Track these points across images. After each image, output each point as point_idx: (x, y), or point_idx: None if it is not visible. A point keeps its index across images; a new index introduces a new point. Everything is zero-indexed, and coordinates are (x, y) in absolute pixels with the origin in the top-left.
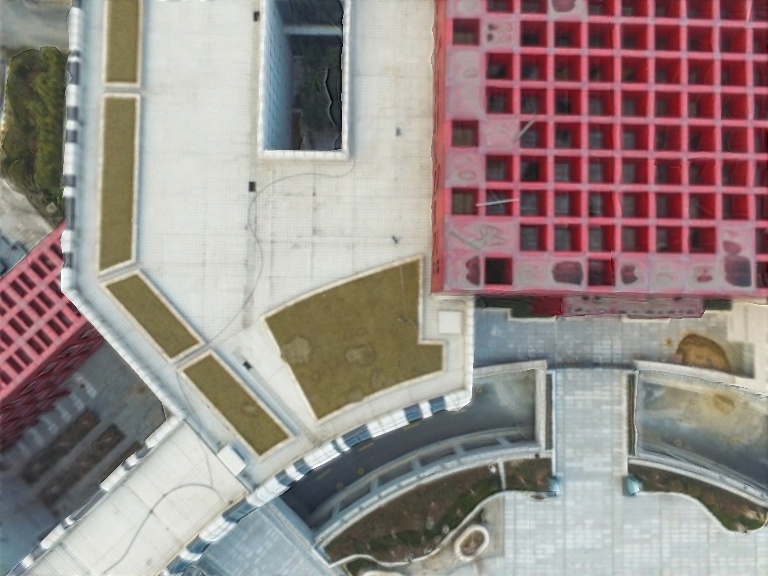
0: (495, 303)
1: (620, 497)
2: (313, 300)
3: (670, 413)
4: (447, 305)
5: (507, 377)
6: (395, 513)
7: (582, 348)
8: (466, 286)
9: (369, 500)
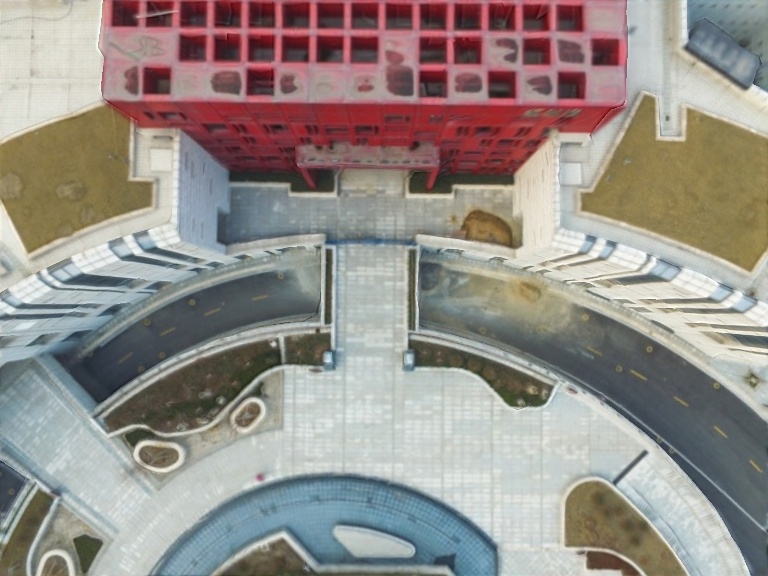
0: (271, 176)
1: (401, 373)
2: (26, 138)
3: (475, 301)
4: (158, 143)
5: (309, 263)
6: (174, 385)
7: (365, 224)
8: (125, 96)
9: (149, 372)
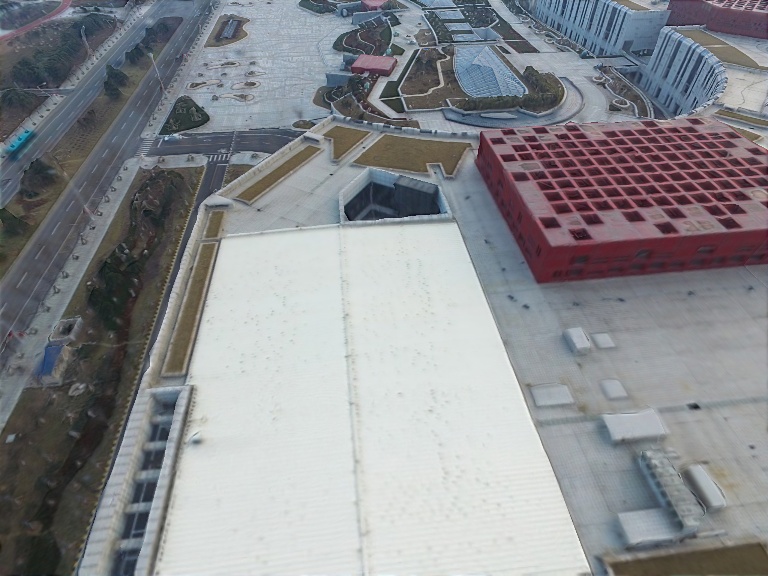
0: None
1: None
2: None
3: None
4: None
5: None
6: None
7: None
8: None
9: None
